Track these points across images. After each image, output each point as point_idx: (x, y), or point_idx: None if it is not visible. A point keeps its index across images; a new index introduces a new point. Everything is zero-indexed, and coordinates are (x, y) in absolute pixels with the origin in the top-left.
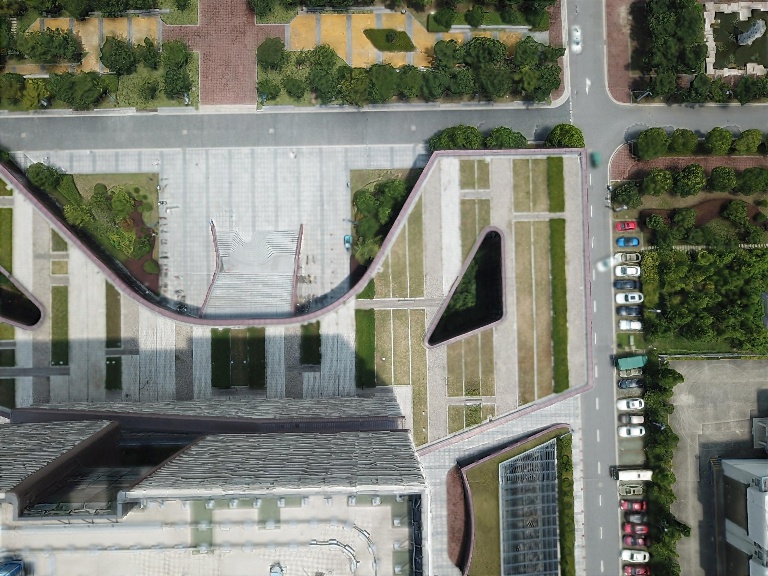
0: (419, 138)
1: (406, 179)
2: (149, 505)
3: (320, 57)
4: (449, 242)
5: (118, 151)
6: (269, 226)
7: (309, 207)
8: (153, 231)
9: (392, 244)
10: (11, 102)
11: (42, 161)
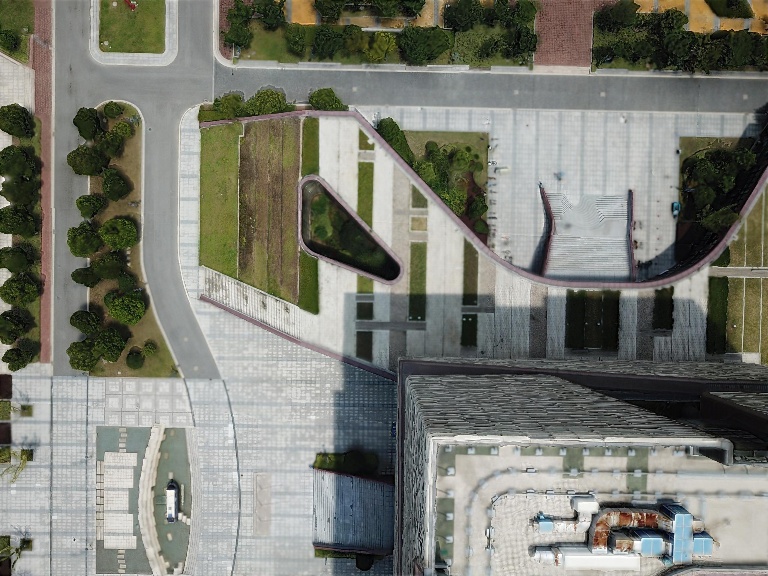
0: (750, 107)
1: (736, 148)
2: None
3: (674, 20)
4: None
5: (449, 109)
6: (597, 190)
7: (637, 173)
8: (483, 191)
9: (748, 213)
10: (344, 55)
11: (373, 116)
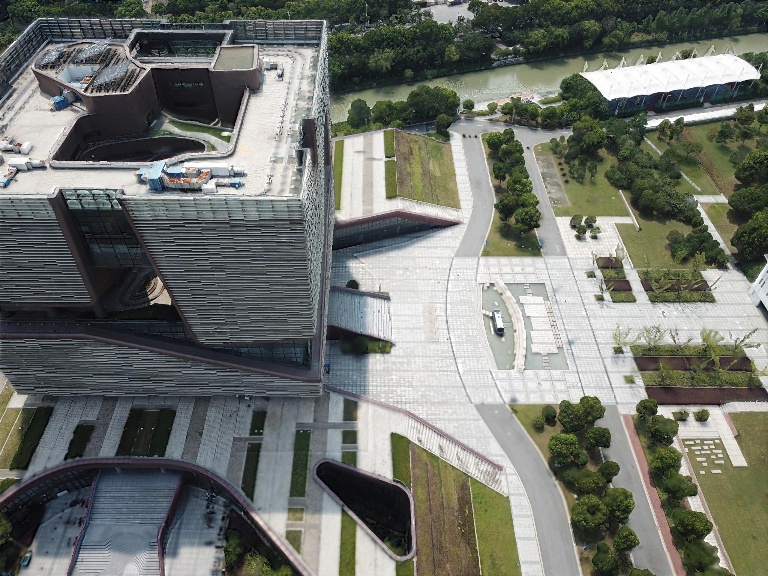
0: None
1: None
2: None
3: None
4: None
5: None
6: None
7: None
8: (225, 575)
9: None
10: None
11: None
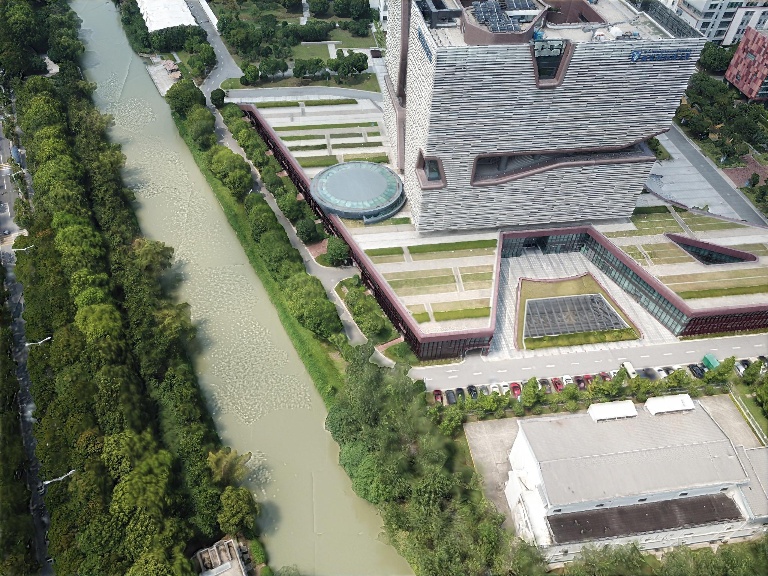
0: None
1: None
2: (639, 15)
3: None
4: (733, 240)
5: (675, 147)
6: (676, 196)
7: None
8: None
9: (713, 217)
10: None
11: None
